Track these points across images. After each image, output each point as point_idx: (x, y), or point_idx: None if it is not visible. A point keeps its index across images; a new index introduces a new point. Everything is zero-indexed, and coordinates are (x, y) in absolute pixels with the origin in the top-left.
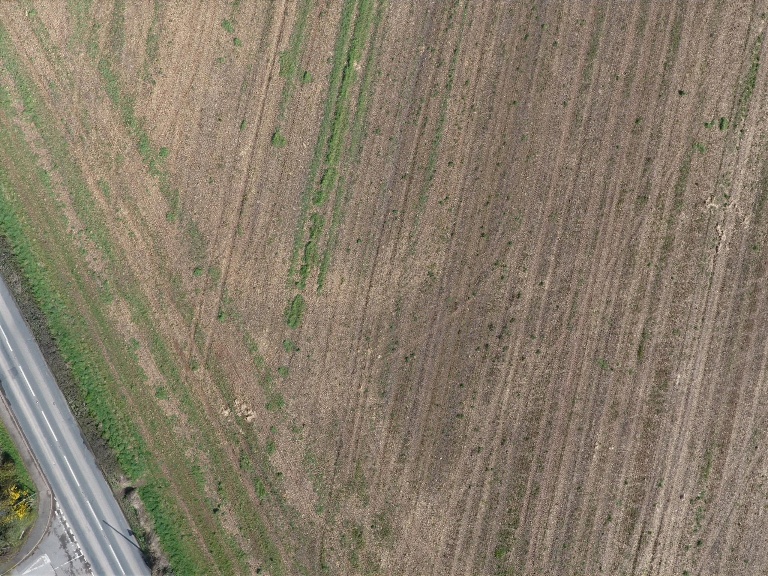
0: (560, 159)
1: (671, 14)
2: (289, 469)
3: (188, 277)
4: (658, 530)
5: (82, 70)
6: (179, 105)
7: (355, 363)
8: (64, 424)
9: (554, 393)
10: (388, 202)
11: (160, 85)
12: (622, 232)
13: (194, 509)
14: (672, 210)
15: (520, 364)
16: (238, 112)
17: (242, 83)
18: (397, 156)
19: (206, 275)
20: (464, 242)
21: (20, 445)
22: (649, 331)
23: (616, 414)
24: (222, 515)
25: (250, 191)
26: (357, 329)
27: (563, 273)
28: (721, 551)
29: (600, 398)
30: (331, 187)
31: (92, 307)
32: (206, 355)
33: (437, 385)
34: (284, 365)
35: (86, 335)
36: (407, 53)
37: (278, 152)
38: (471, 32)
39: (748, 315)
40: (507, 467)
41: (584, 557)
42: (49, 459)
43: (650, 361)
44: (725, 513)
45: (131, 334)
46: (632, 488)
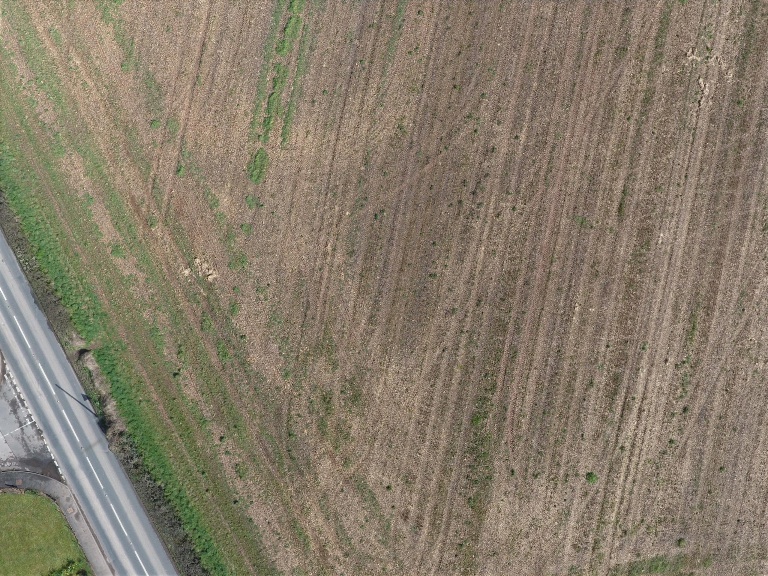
0: (535, 9)
1: None
2: (253, 331)
3: (145, 130)
4: (642, 396)
5: None
6: None
7: (322, 220)
8: (14, 282)
9: (531, 251)
10: (355, 52)
11: None
12: (600, 84)
13: (153, 373)
14: (652, 62)
15: (495, 221)
16: None
17: None
18: (364, 4)
19: (164, 128)
20: (435, 94)
21: None
22: (630, 187)
23: (596, 274)
24: (182, 380)
25: (210, 40)
26: (324, 184)
27: (539, 126)
28: (708, 418)
29: (580, 257)
30: (295, 36)
31: (43, 160)
32: (164, 212)
33: (408, 243)
34: (247, 222)
35: (37, 190)
36: None
37: None
38: None
39: (733, 172)
40: (483, 329)
41: (565, 424)
42: None
43: (631, 219)
44: (712, 378)
45: (85, 189)
46: (614, 351)
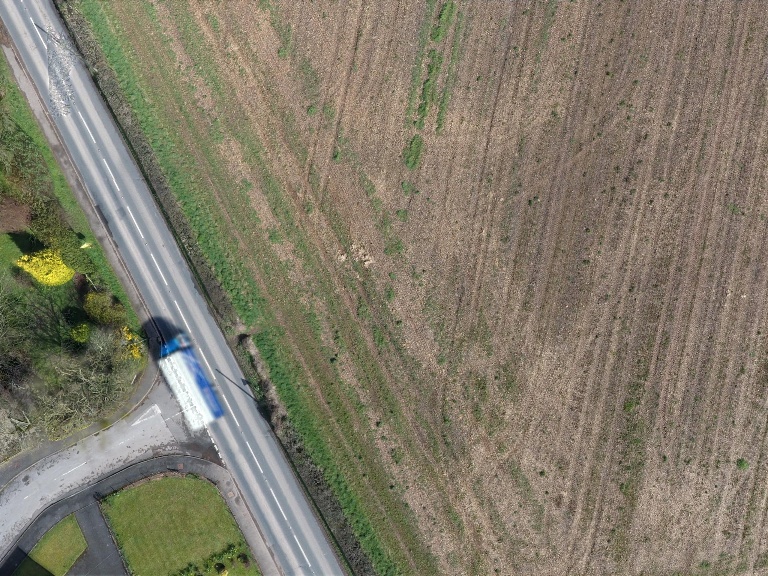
0: None
1: None
2: (409, 317)
3: (301, 116)
4: None
5: None
6: None
7: (476, 206)
8: (174, 268)
9: (684, 238)
10: (509, 39)
11: None
12: (751, 71)
13: (310, 358)
14: None
15: (648, 208)
16: None
17: None
18: None
19: (320, 114)
20: (588, 81)
21: (128, 289)
22: None
23: (748, 260)
24: (339, 365)
25: (365, 27)
26: (478, 171)
27: (691, 113)
28: None
29: (731, 244)
30: (450, 22)
31: (202, 146)
32: (321, 198)
33: (562, 229)
34: (403, 208)
35: (196, 175)
36: None
37: None
38: None
39: None
40: (635, 316)
41: (716, 410)
42: (159, 304)
43: None
44: None
45: (243, 175)
46: (765, 338)
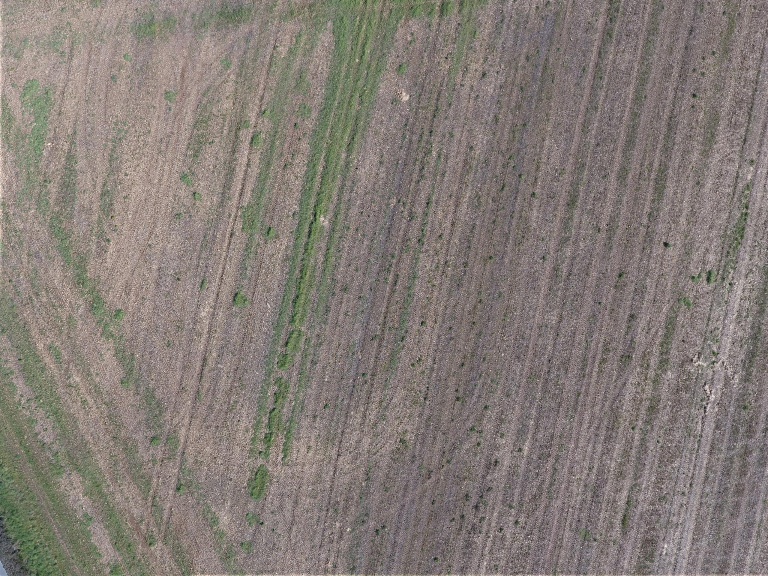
0: (539, 317)
1: (655, 162)
2: None
3: (145, 447)
4: None
5: (32, 228)
6: (135, 264)
7: (323, 537)
8: None
9: (534, 566)
10: (357, 365)
11: (115, 243)
12: (605, 394)
13: None
14: (657, 369)
15: (498, 536)
16: (198, 271)
17: (202, 240)
18: (367, 316)
19: (164, 444)
20: (438, 406)
21: None
22: (634, 498)
23: None
24: None
25: (211, 355)
26: (325, 500)
27: (543, 438)
28: None
29: (583, 570)
30: (297, 350)
31: (42, 481)
32: (164, 530)
33: (410, 559)
34: (247, 540)
35: (35, 511)
36: (377, 206)
37: (240, 313)
38: (445, 183)
39: (738, 479)
40: None
41: None
42: None
43: (635, 530)
44: None
45: (84, 509)
46: None
